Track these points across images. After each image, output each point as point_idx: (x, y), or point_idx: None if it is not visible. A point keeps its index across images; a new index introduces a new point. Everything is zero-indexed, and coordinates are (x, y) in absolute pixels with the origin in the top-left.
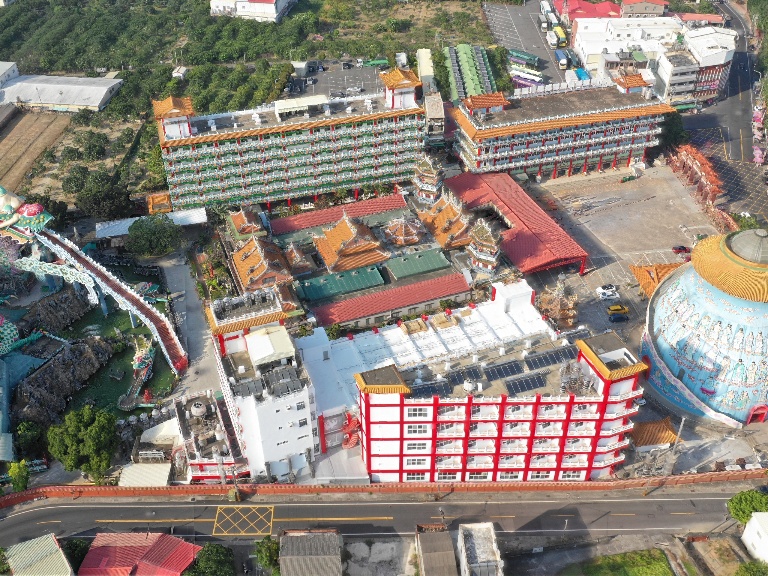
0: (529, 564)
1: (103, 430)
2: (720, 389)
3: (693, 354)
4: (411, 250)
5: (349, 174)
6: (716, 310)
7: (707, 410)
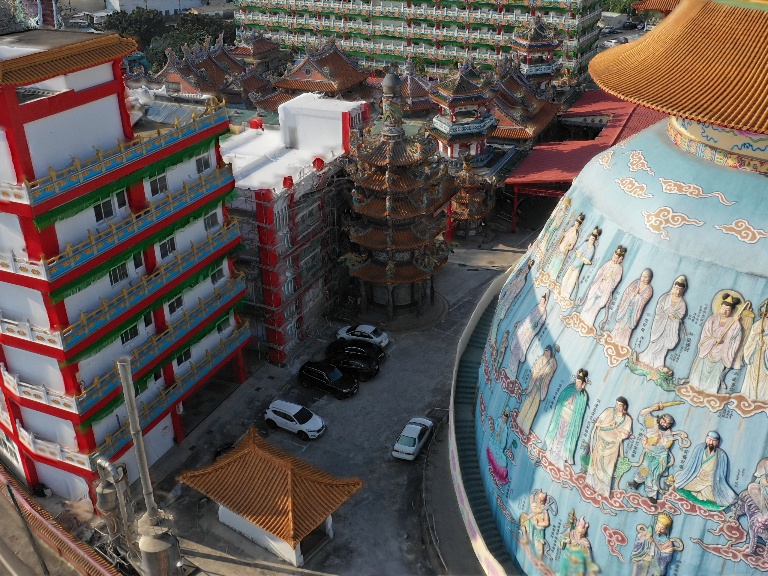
0: None
1: None
2: (516, 469)
3: (499, 322)
4: None
5: (454, 50)
6: (596, 180)
7: (471, 529)
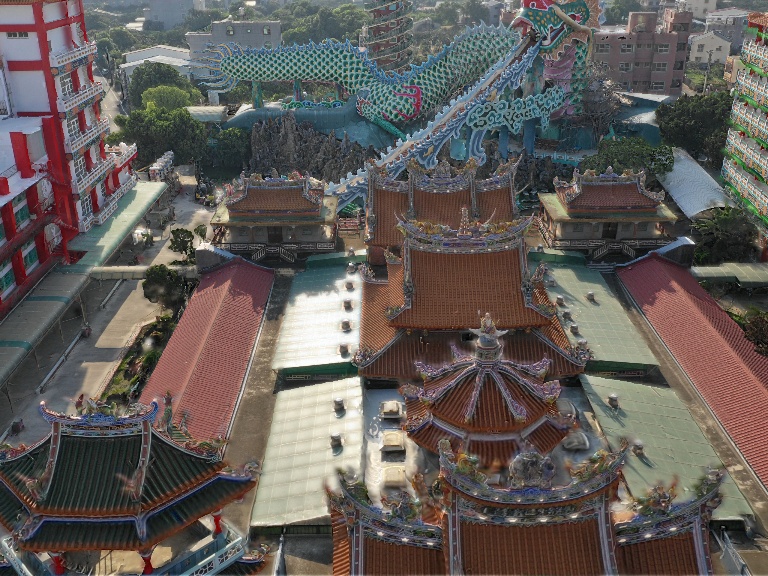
0: None
1: (135, 119)
2: None
3: None
4: (389, 433)
5: None
6: None
7: None
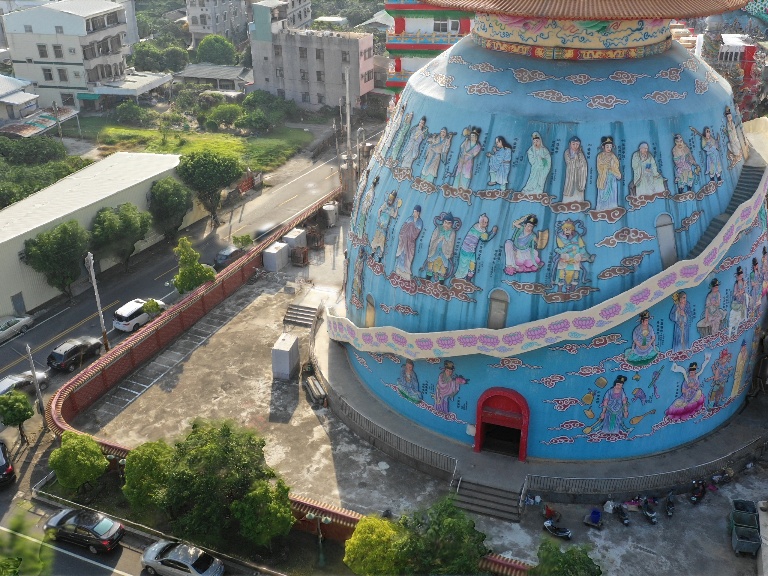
0: (339, 127)
1: None
2: None
3: None
4: None
5: None
6: None
7: None
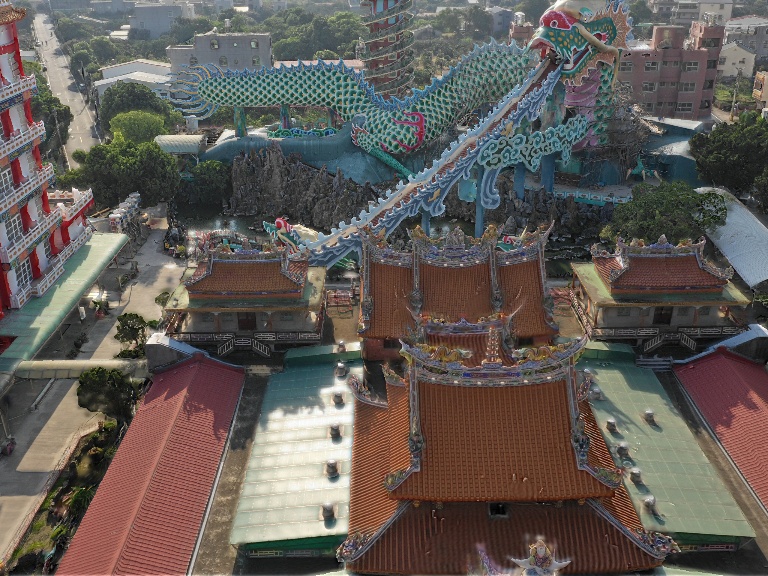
0: None
1: (96, 156)
2: None
3: None
4: None
5: None
6: None
7: None
